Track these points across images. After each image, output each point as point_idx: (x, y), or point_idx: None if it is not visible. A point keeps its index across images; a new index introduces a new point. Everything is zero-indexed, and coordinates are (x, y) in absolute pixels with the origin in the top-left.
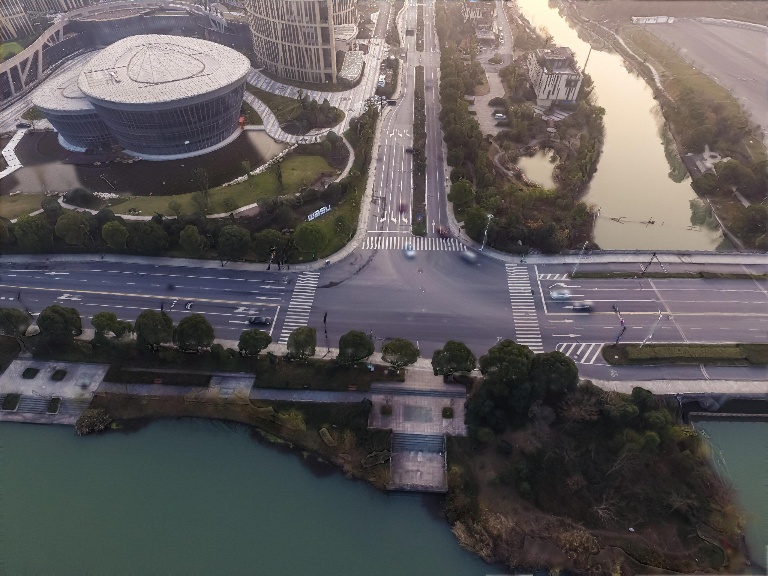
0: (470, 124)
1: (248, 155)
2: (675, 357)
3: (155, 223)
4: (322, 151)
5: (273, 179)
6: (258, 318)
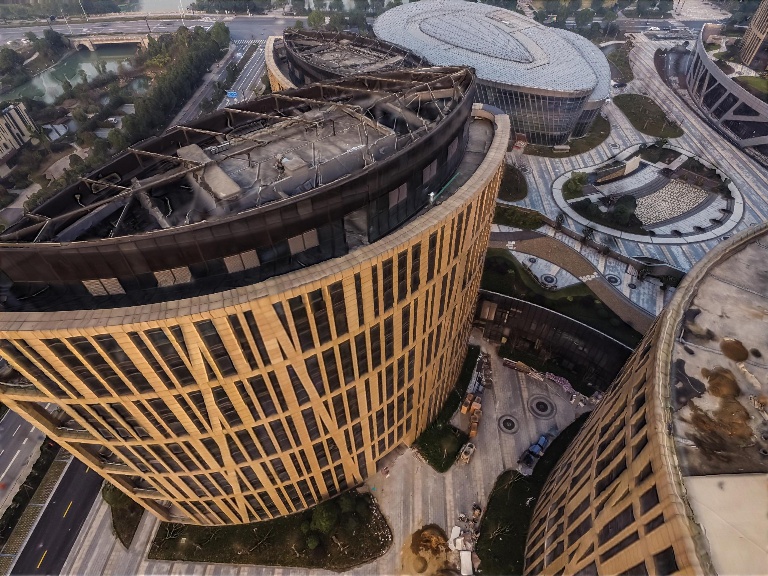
0: None
1: None
2: None
3: None
4: None
5: None
6: None
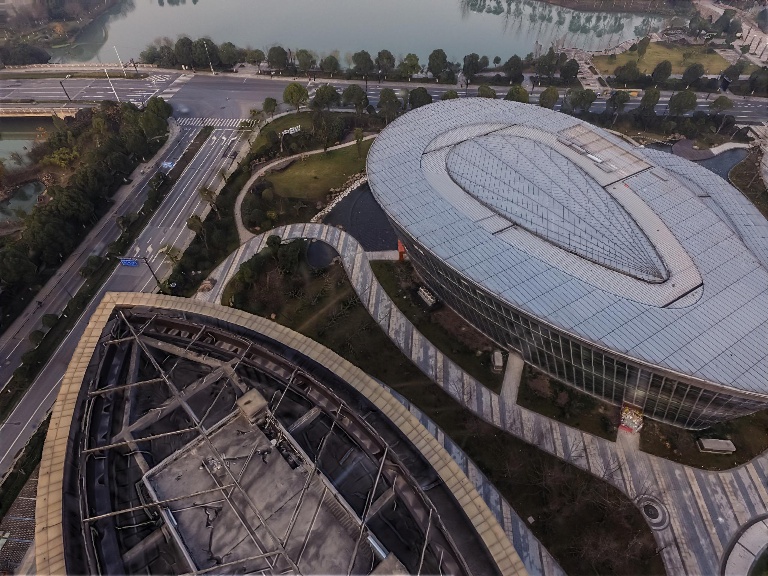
0: (47, 206)
1: (378, 205)
2: (113, 72)
3: (417, 93)
4: (277, 202)
5: (338, 166)
6: (336, 90)
